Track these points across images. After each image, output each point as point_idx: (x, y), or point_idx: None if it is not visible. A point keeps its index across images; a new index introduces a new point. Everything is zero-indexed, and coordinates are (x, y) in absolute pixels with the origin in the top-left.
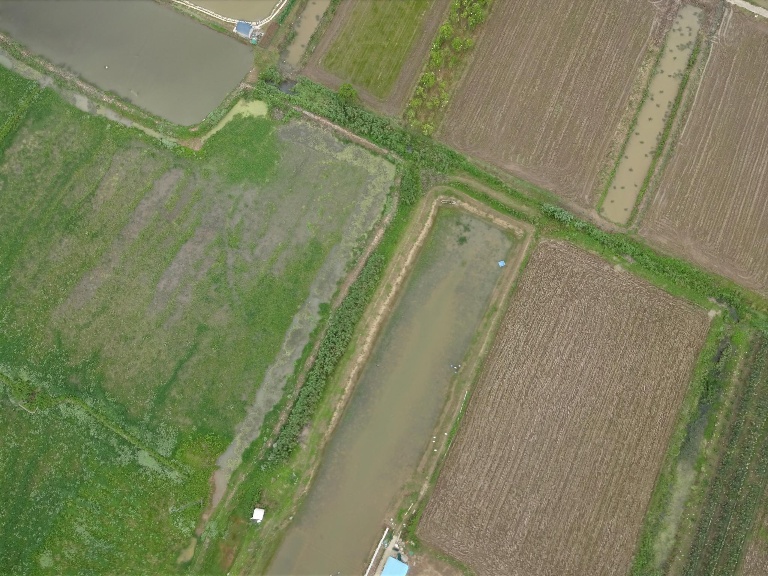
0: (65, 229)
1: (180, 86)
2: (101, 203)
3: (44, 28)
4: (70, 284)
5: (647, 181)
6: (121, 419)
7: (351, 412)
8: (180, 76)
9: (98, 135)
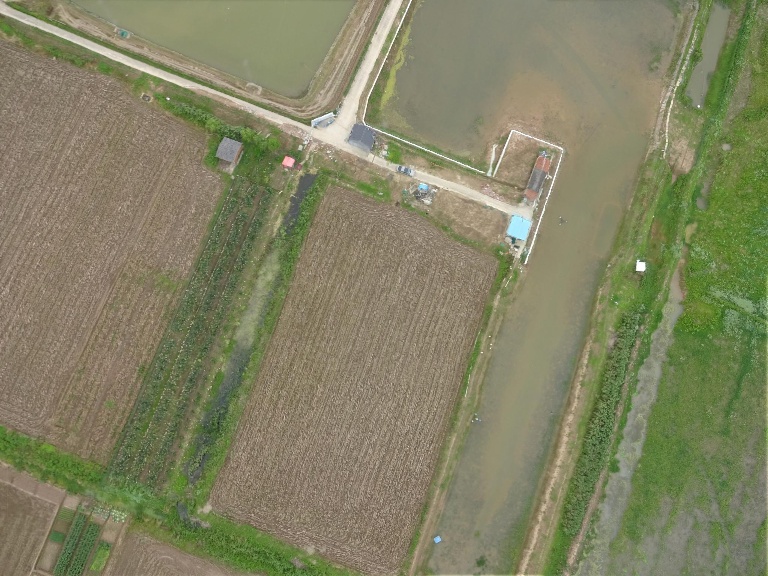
0: None
1: None
2: None
3: None
4: None
5: None
6: None
7: (571, 365)
8: None
9: None
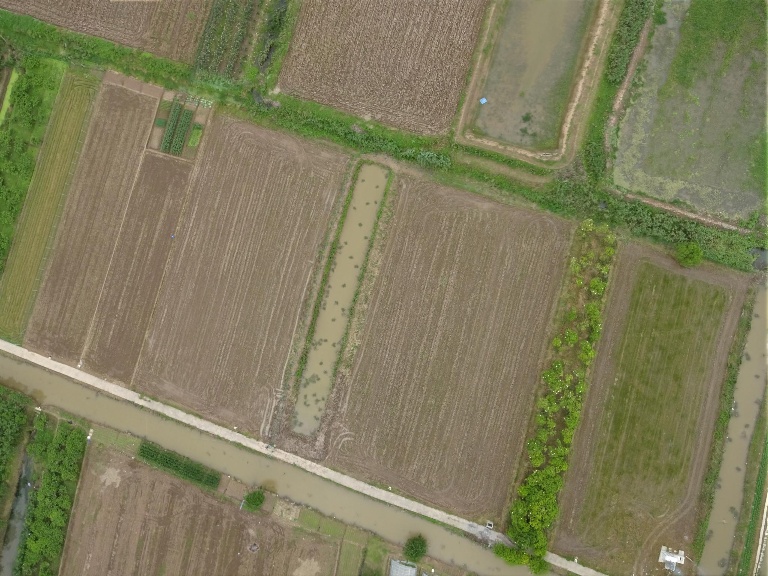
0: None
1: None
2: None
3: None
4: None
5: (345, 212)
6: None
7: None
8: None
9: None
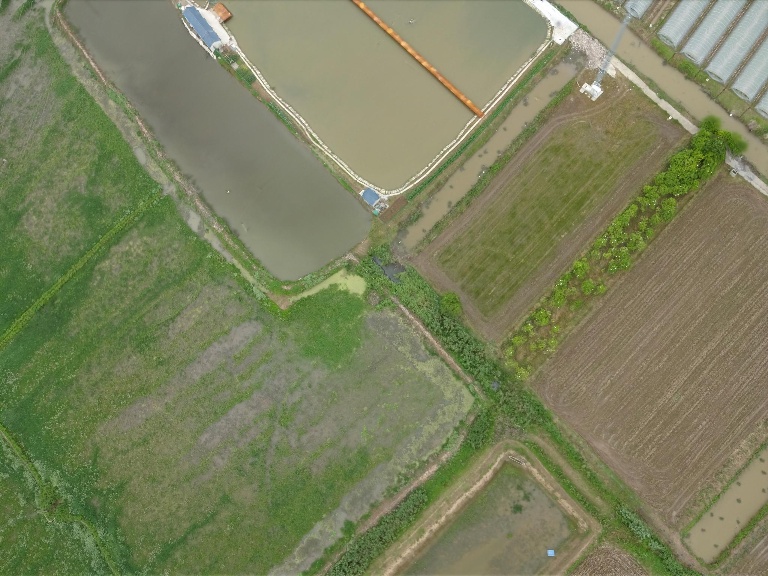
0: (137, 346)
1: (290, 235)
2: (177, 332)
3: (186, 133)
4: (123, 404)
5: (753, 524)
6: (122, 562)
7: None
8: (293, 224)
9: (197, 261)
